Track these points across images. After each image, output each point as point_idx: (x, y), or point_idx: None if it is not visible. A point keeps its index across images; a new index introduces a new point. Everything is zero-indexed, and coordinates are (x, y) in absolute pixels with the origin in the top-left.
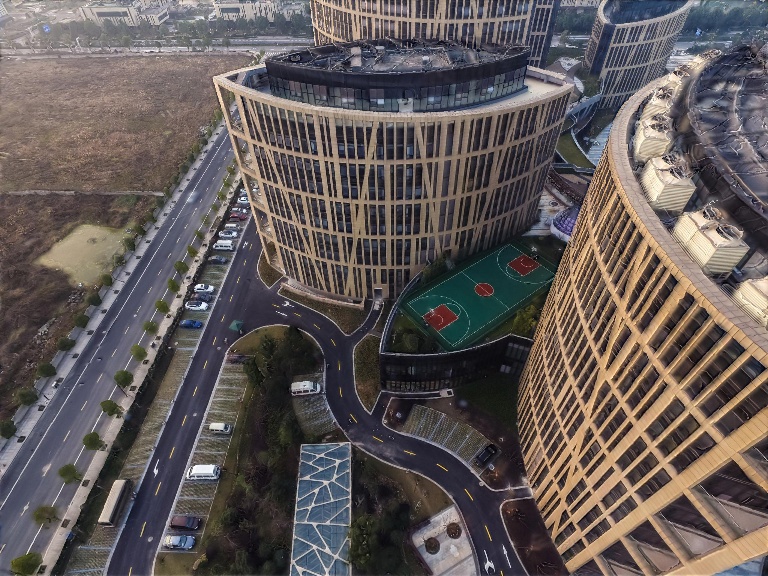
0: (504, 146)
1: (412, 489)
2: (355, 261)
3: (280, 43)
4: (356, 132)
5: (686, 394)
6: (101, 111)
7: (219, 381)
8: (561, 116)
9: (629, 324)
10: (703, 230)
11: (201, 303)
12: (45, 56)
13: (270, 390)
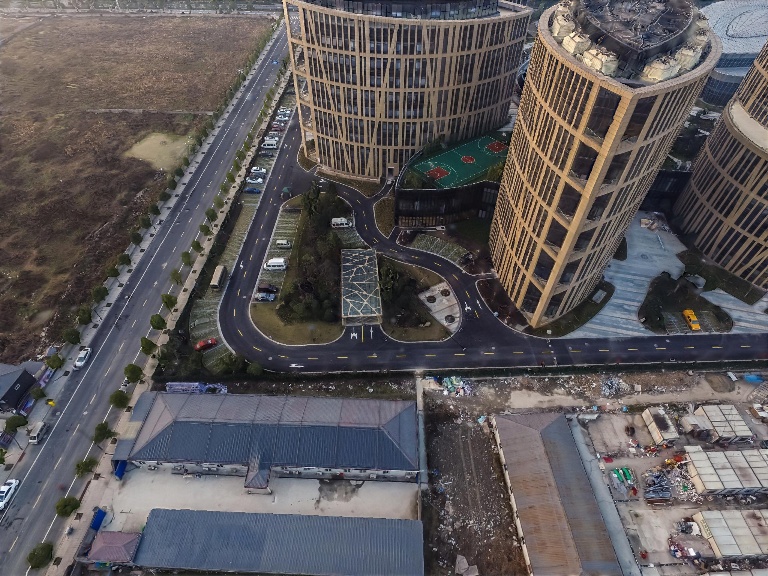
0: (483, 50)
1: (417, 274)
2: (375, 142)
3: (296, 9)
4: (383, 32)
5: (563, 120)
6: (149, 56)
7: (278, 222)
8: (523, 34)
9: (542, 102)
10: (573, 38)
11: (258, 178)
12: (88, 14)
13: (318, 219)
